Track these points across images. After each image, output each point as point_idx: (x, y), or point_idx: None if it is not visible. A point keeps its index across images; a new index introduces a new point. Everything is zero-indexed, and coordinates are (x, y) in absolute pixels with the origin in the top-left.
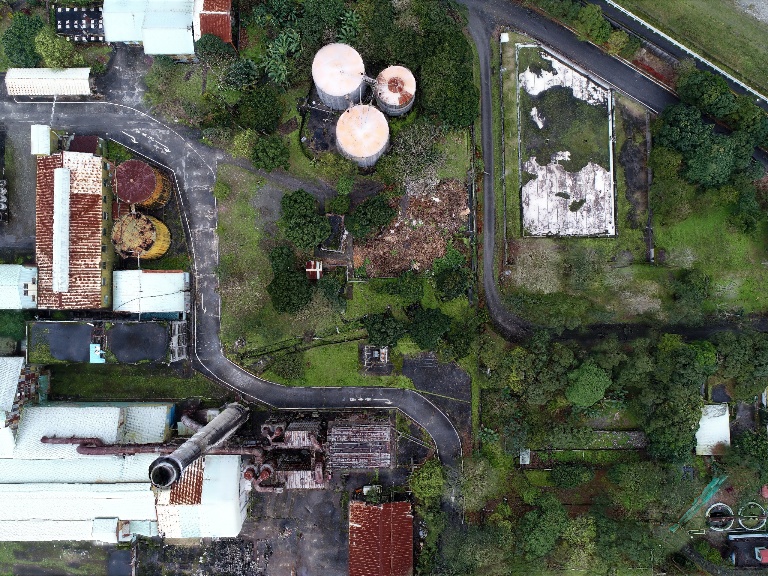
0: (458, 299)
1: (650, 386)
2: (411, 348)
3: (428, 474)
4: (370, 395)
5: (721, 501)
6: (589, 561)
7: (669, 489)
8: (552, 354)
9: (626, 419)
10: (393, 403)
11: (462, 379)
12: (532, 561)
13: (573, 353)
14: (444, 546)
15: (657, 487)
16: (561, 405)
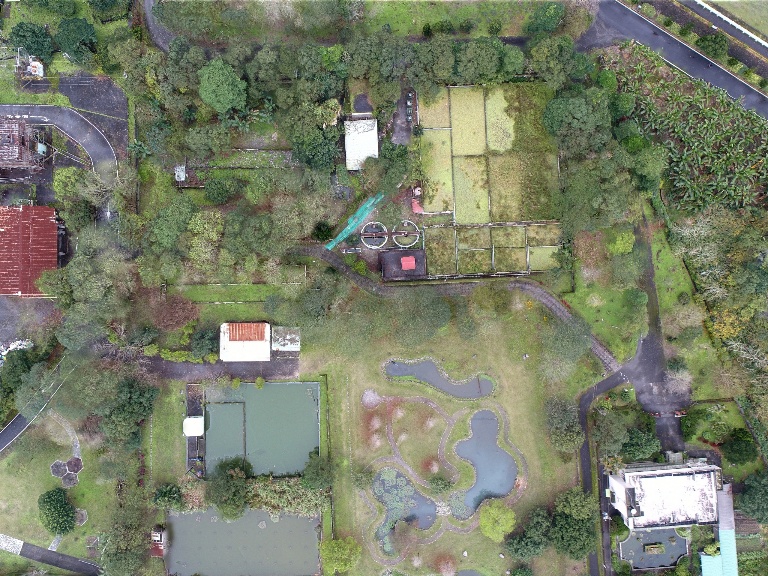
0: (118, 21)
1: (283, 88)
2: (67, 66)
3: (60, 170)
4: (27, 112)
5: (377, 220)
6: (216, 254)
7: (306, 192)
8: (184, 53)
9: (284, 139)
10: (50, 120)
11: (118, 97)
12: (161, 254)
13: (203, 51)
14: (98, 259)
15: (298, 194)
16: (203, 112)
